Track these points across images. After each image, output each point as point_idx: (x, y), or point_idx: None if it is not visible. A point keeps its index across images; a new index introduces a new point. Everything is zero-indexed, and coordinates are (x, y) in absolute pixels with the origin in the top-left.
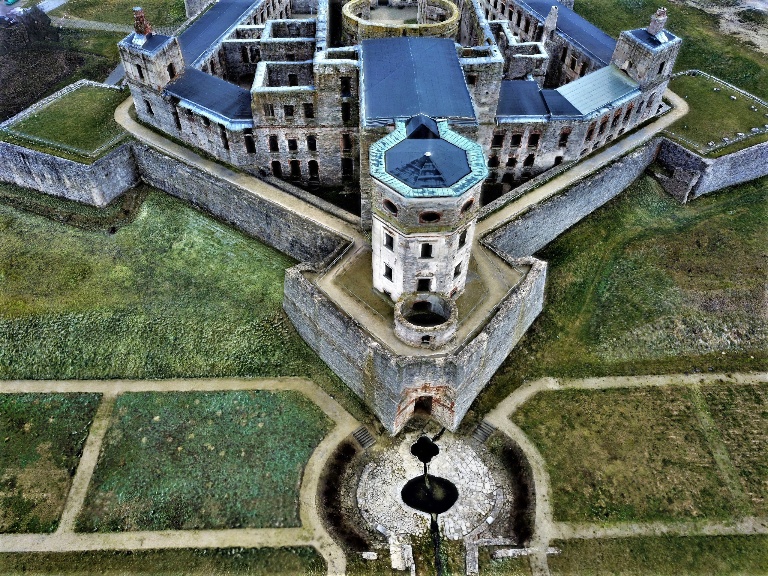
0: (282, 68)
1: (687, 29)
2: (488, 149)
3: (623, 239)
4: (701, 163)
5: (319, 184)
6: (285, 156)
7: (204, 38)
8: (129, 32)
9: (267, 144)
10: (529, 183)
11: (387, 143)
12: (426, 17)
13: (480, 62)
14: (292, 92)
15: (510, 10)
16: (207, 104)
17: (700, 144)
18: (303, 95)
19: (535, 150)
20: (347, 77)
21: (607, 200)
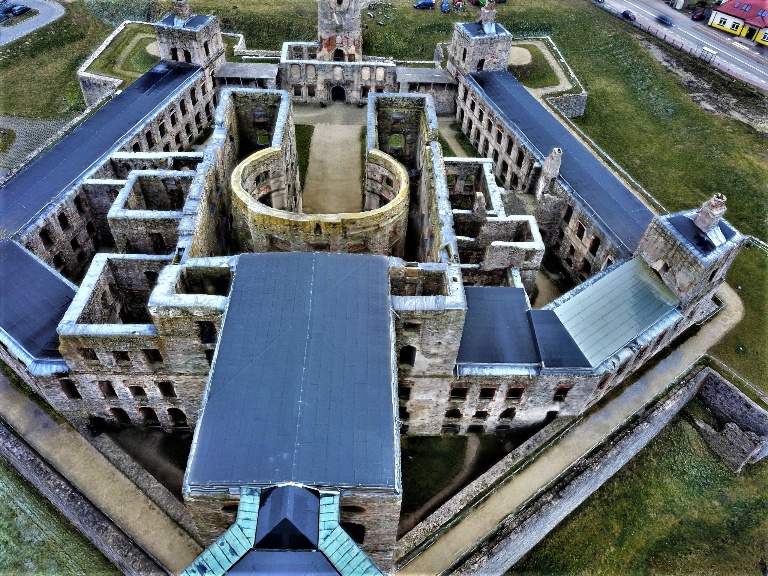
0: (133, 264)
1: (732, 156)
2: (444, 401)
3: (646, 542)
4: (767, 423)
5: (189, 431)
6: (129, 403)
7: (55, 178)
8: (2, 127)
9: (97, 390)
10: (505, 463)
11: (210, 568)
12: (367, 176)
13: (427, 307)
14: (121, 336)
15: (499, 131)
16: (8, 322)
17: (764, 385)
18: (140, 340)
19: (517, 404)
20: (208, 321)
21: (623, 464)
